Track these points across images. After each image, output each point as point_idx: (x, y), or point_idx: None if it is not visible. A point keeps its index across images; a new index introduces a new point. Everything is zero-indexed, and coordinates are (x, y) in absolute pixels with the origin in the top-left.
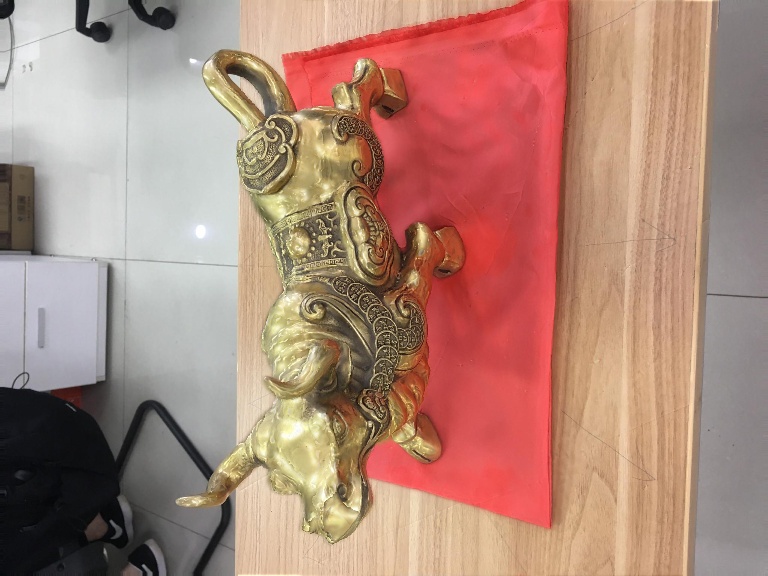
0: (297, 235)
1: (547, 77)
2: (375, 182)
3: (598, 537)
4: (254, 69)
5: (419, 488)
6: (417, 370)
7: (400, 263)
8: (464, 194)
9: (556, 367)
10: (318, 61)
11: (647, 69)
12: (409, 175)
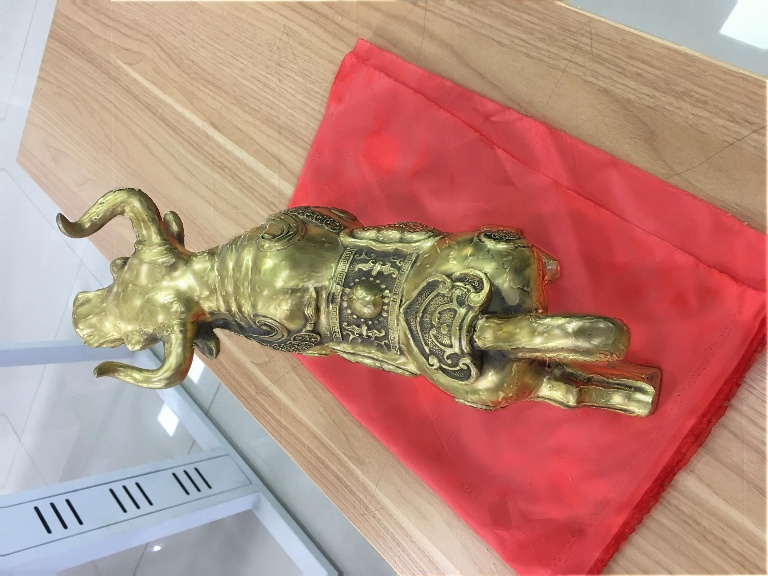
0: (370, 308)
1: (506, 545)
2: None
3: None
4: None
5: None
6: None
7: None
8: None
9: None
10: (759, 320)
11: None
12: None
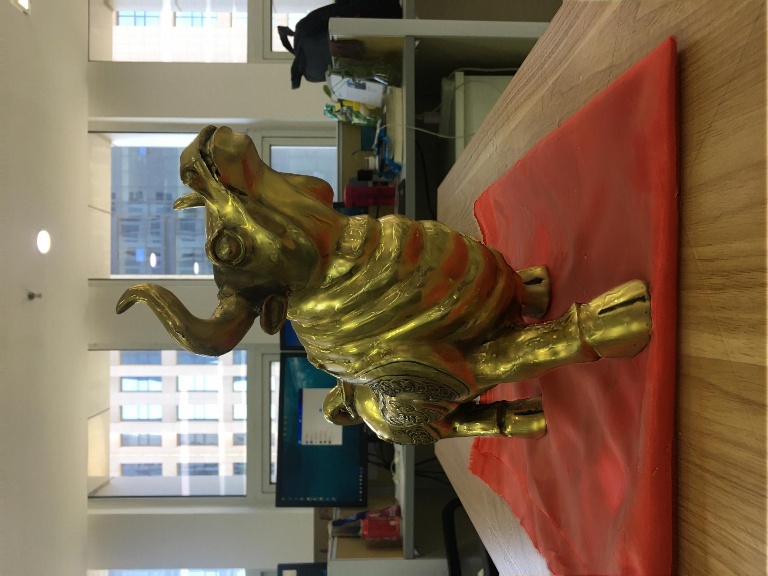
0: None
1: None
2: None
3: None
4: None
5: (654, 316)
6: None
7: None
8: None
9: None
10: None
11: None
12: None
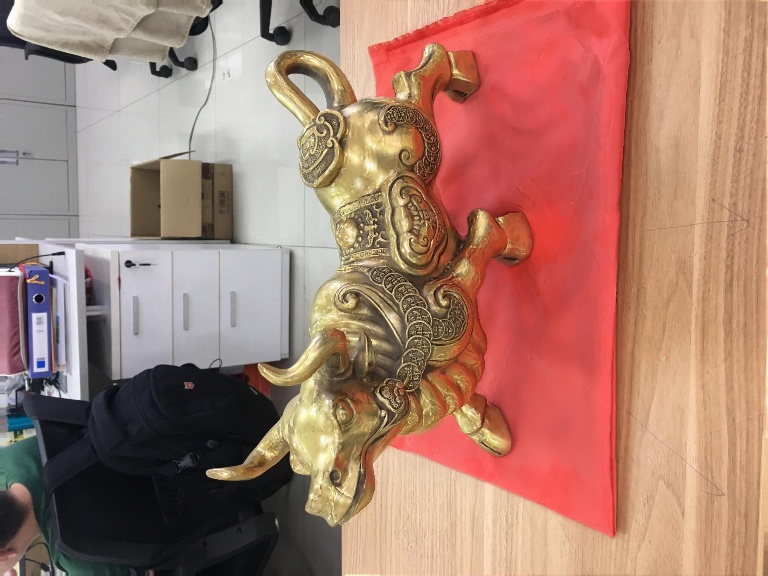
0: (347, 226)
1: (607, 45)
2: (428, 170)
3: (664, 552)
4: (316, 66)
5: (490, 481)
6: (465, 361)
7: (455, 252)
8: (531, 177)
9: (622, 363)
10: (400, 50)
11: (718, 25)
12: (482, 160)
